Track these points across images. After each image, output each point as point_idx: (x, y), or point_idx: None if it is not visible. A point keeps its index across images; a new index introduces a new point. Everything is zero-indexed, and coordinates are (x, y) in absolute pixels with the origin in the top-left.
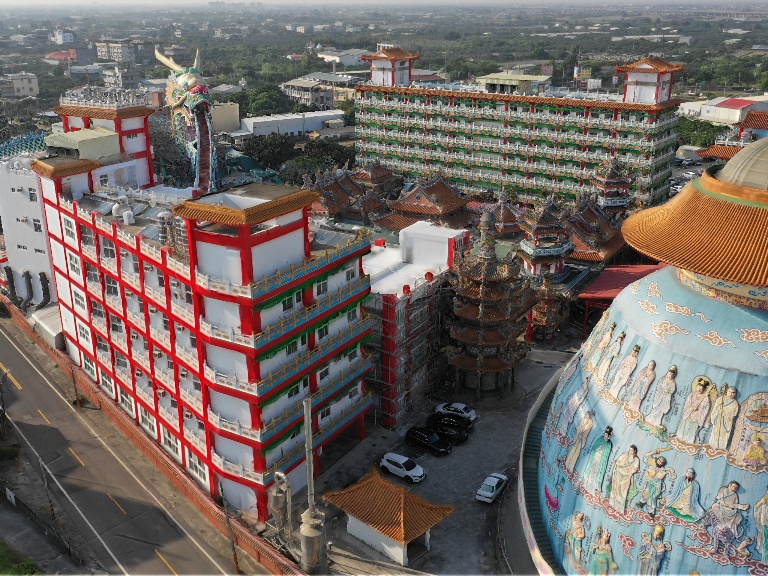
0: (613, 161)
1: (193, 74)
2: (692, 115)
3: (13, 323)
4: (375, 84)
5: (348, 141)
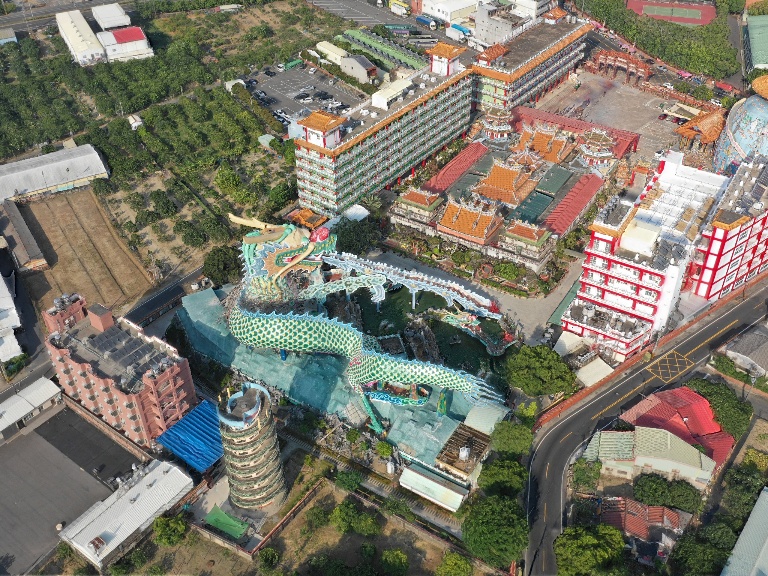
0: (500, 106)
1: (297, 228)
2: (100, 58)
3: (661, 348)
4: (329, 146)
5: (52, 246)
